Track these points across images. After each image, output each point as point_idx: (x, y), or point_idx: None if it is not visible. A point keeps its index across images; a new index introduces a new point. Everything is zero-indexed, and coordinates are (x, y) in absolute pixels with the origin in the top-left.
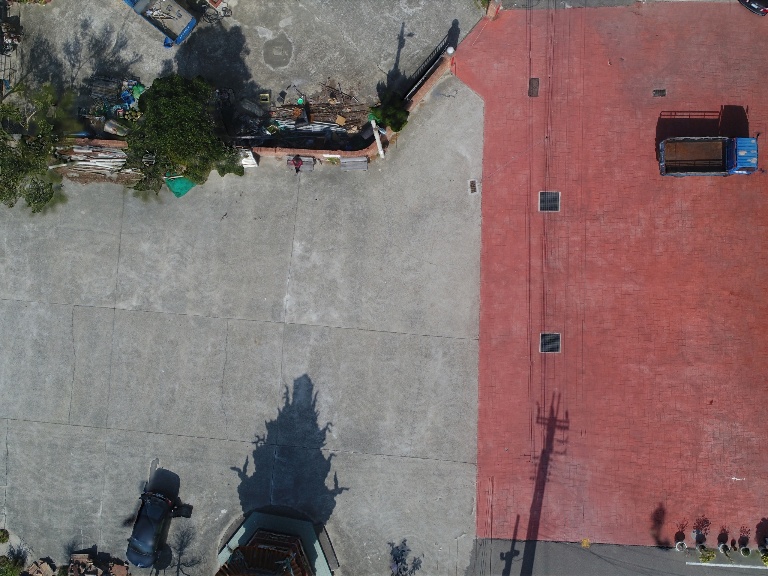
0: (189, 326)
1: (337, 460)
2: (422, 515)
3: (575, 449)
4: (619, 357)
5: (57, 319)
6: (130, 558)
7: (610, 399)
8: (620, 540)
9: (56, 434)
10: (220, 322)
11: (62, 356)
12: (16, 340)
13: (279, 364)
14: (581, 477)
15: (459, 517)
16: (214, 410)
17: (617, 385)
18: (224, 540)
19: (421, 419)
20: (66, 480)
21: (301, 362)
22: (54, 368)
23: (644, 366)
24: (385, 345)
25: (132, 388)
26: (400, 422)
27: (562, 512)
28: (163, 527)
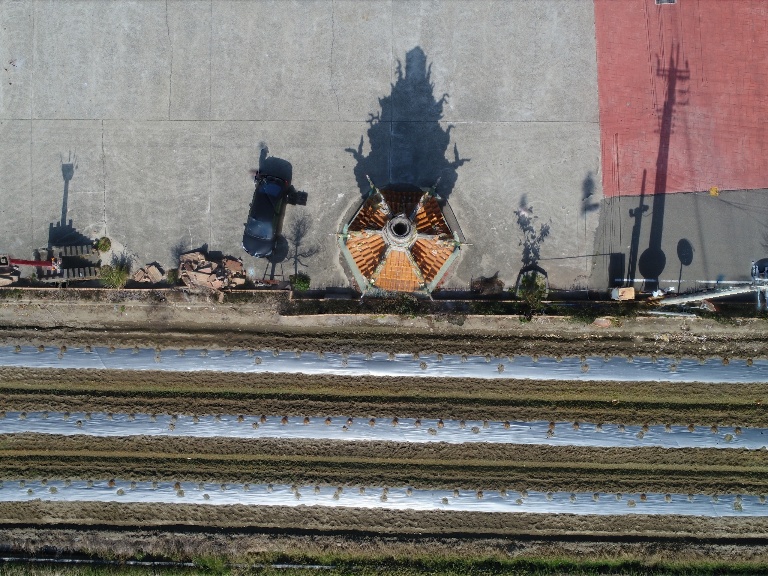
0: (292, 7)
1: (456, 131)
2: (547, 180)
3: (697, 98)
4: (735, 2)
5: (150, 11)
6: (247, 246)
7: (729, 45)
8: (748, 185)
9: (156, 131)
10: (325, 0)
11: (158, 49)
12: (106, 36)
13: (389, 38)
14: (705, 126)
15: (585, 178)
16: (324, 91)
17: (735, 30)
18: (343, 225)
19: (540, 82)
20: (170, 179)
21: (412, 34)
22: (150, 62)
23: (760, 8)
24: (498, 10)
25: (235, 76)
26: (518, 87)
27: (689, 162)
28: (281, 208)
